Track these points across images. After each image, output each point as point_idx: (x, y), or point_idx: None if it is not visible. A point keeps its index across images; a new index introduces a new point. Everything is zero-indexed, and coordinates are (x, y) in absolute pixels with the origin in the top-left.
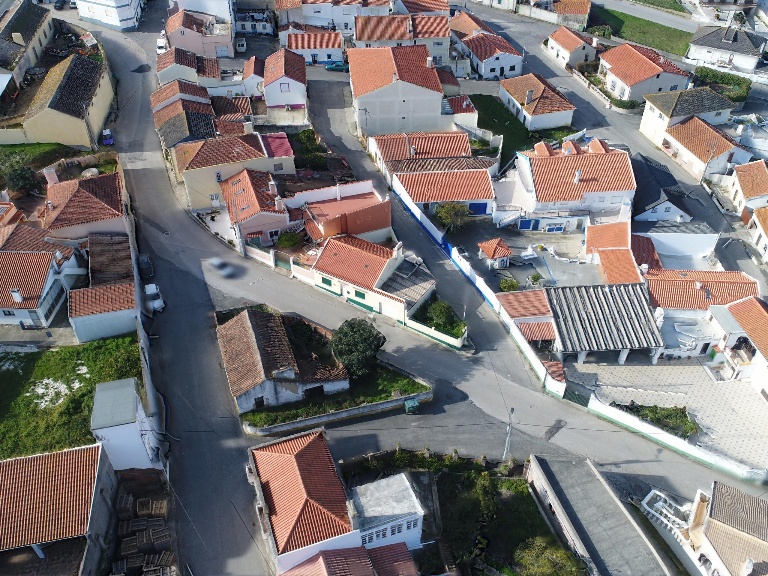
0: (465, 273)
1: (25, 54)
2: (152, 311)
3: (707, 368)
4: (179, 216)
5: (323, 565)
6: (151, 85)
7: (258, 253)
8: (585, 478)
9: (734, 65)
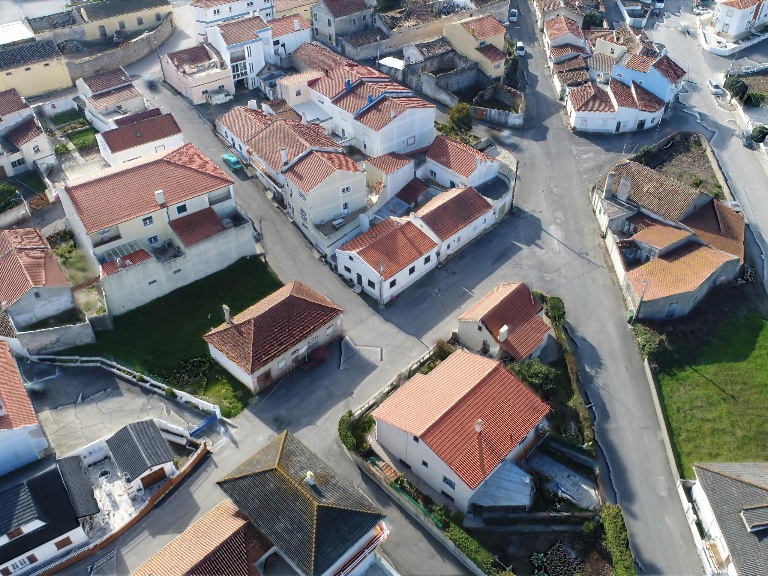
0: None
1: (77, 27)
2: None
3: None
4: None
5: None
6: None
7: None
8: None
9: (728, 575)
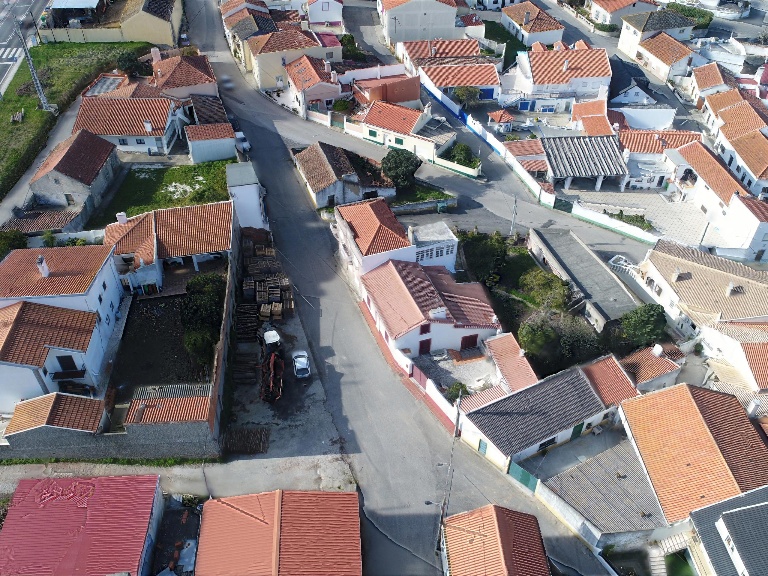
0: (478, 134)
1: None
2: (242, 149)
3: (662, 195)
4: (251, 93)
5: (392, 265)
6: (212, 6)
7: (318, 116)
8: (569, 242)
9: (700, 3)
